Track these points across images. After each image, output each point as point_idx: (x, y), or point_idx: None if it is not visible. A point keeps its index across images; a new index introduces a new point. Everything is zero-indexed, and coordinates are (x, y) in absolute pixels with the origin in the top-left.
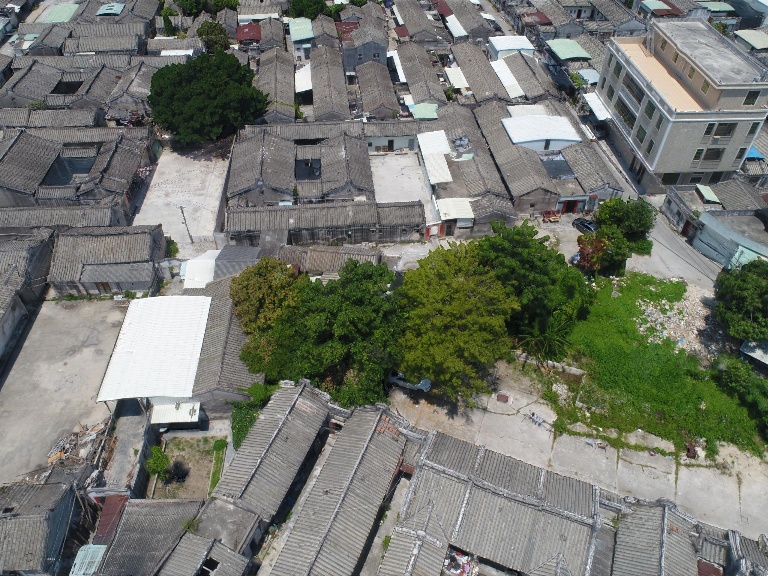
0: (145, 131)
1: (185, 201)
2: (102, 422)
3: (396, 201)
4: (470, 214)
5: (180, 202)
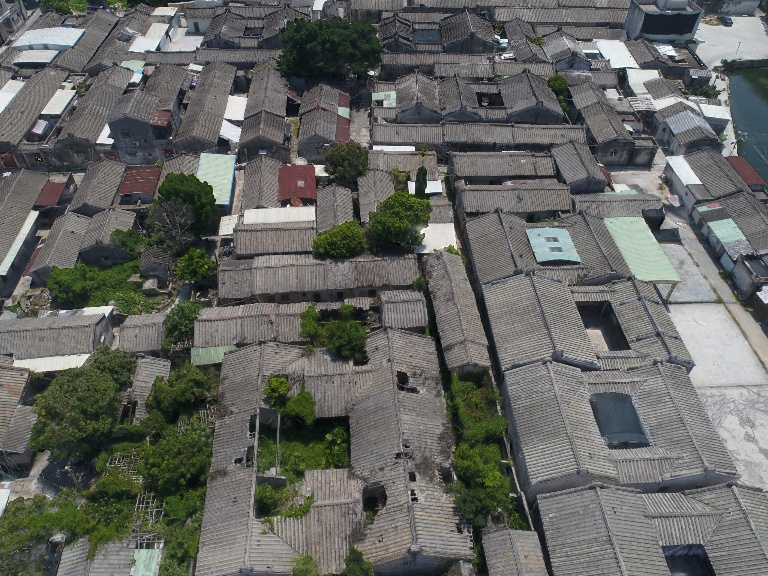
0: None
1: None
2: None
3: (196, 44)
4: (158, 8)
5: None
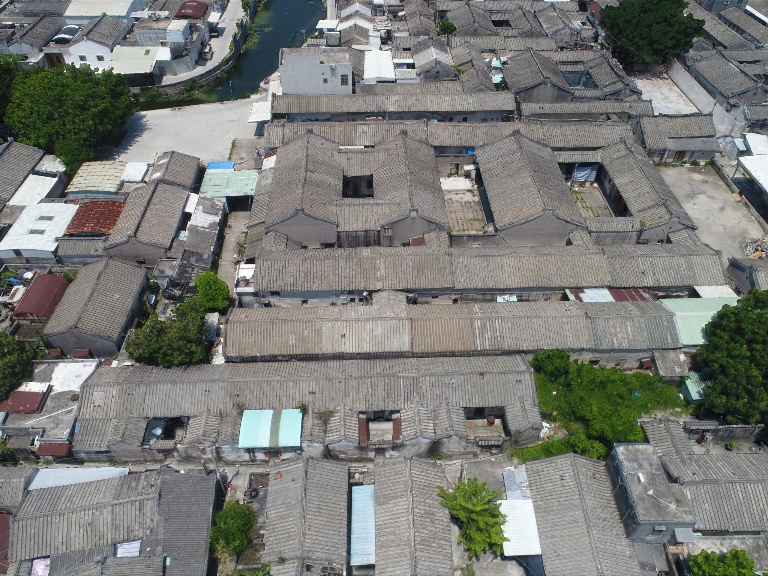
0: (608, 53)
1: (663, 106)
2: (763, 237)
3: None
4: None
5: (660, 107)
